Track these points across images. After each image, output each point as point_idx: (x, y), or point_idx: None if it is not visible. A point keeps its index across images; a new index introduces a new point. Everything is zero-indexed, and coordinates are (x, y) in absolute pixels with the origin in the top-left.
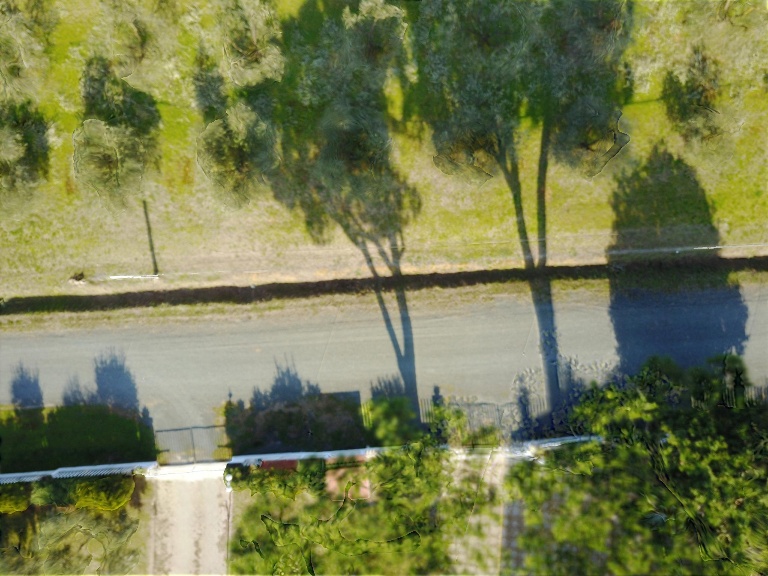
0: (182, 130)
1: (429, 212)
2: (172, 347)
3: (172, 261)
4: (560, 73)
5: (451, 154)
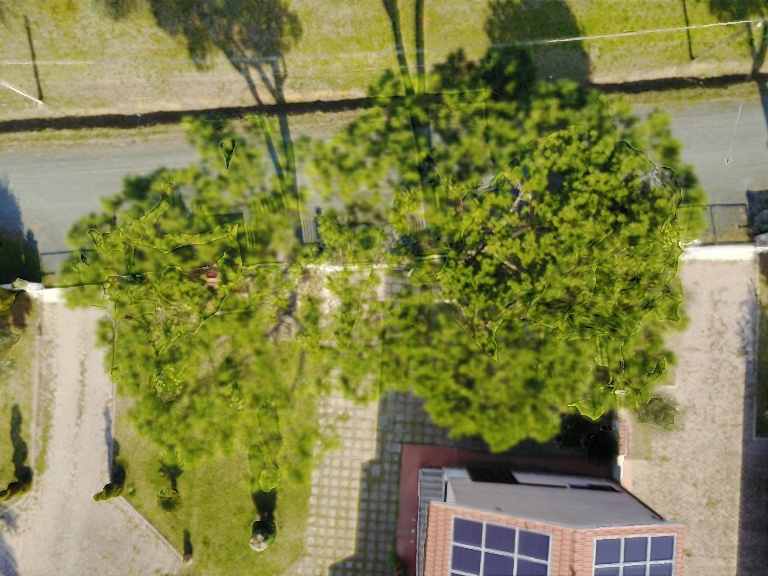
0: None
1: (311, 39)
2: (56, 170)
3: (57, 87)
4: None
5: None
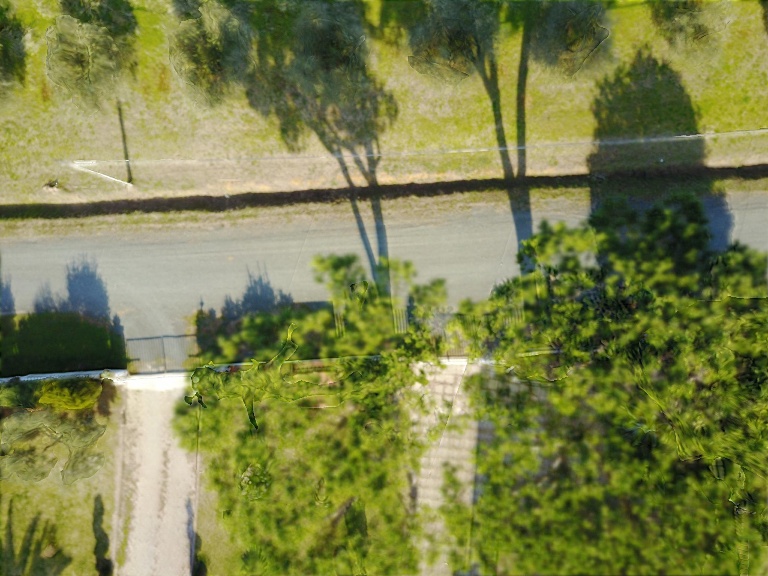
0: (158, 37)
1: (406, 120)
2: (144, 254)
3: (146, 169)
4: None
5: (427, 57)
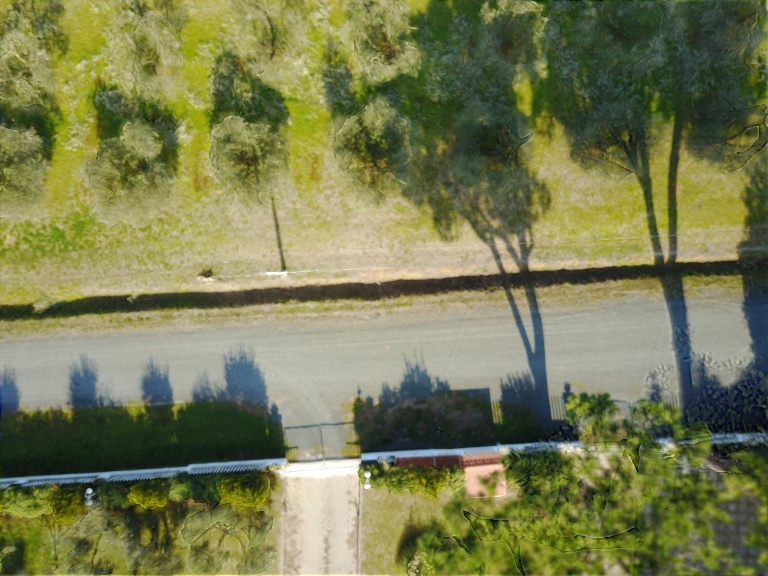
0: (310, 127)
1: (558, 208)
2: (301, 344)
3: (300, 258)
4: (693, 67)
5: (585, 149)
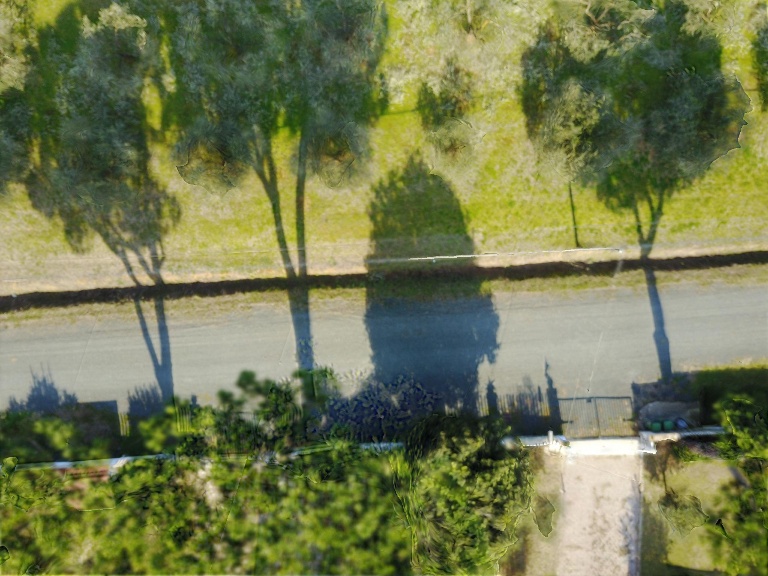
0: None
1: (189, 221)
2: None
3: None
4: (316, 84)
5: (202, 164)
